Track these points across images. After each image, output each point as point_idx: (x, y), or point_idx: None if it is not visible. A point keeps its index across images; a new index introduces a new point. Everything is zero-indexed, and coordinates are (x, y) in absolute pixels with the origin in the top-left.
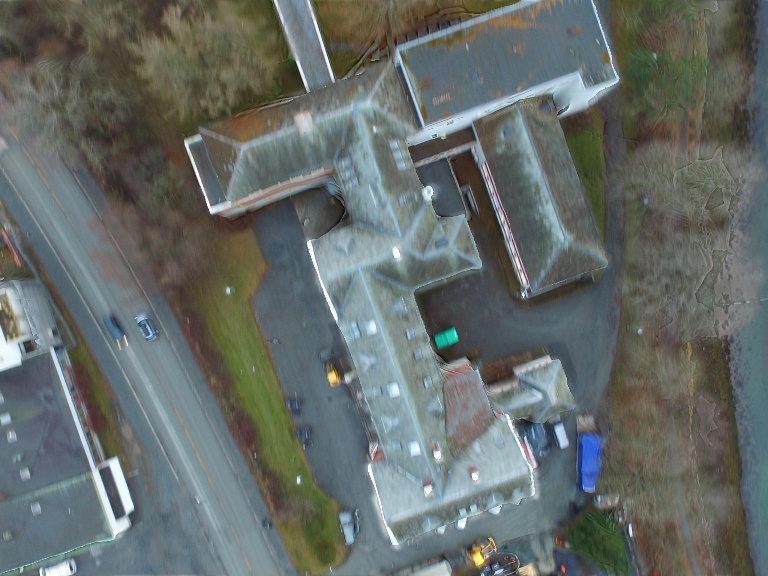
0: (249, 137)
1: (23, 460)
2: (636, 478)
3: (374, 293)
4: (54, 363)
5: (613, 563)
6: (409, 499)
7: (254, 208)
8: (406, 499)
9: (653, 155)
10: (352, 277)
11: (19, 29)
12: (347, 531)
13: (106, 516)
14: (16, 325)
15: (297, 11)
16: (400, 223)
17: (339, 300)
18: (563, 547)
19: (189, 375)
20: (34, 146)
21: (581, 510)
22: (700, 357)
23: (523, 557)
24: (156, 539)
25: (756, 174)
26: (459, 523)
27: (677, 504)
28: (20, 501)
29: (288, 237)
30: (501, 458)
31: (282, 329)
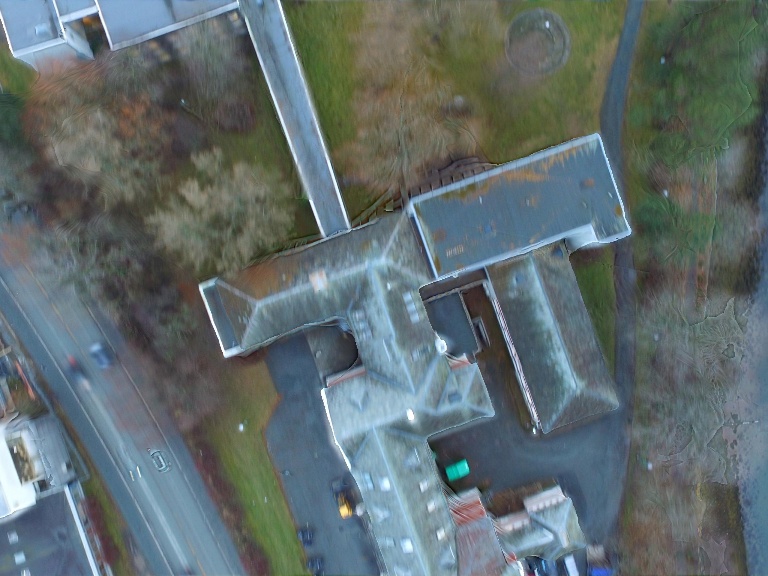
0: (264, 293)
1: None
2: None
3: (388, 450)
4: (68, 502)
5: None
6: None
7: (267, 343)
8: None
9: (663, 286)
10: (366, 434)
11: (37, 191)
12: None
13: None
14: (31, 467)
15: (311, 151)
16: (414, 379)
17: (353, 453)
18: None
19: (201, 506)
20: (48, 280)
21: None
22: None
23: None
24: None
25: (765, 294)
26: None
27: None
28: None
29: (300, 369)
30: None
31: (294, 460)
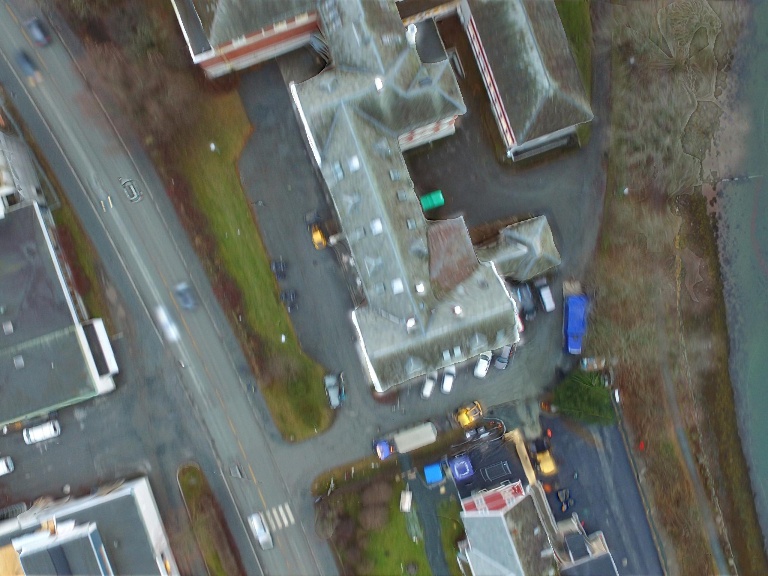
0: None
1: (6, 313)
2: (623, 345)
3: (357, 128)
4: (37, 216)
5: (598, 410)
6: (392, 337)
7: (239, 67)
8: (389, 337)
9: (640, 19)
10: (335, 112)
11: None
12: (332, 393)
13: (89, 370)
14: None
15: None
16: (383, 60)
17: (322, 140)
18: (549, 411)
19: (174, 237)
20: (18, 5)
21: (567, 374)
22: (688, 232)
23: (509, 423)
24: (140, 402)
25: (744, 50)
26: (445, 386)
27: (664, 377)
28: (3, 355)
29: (273, 99)
30: (484, 297)
31: (267, 192)
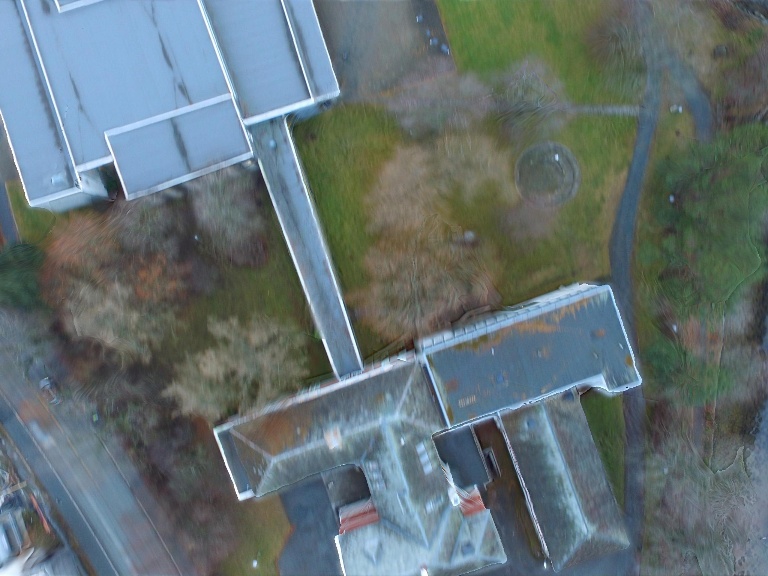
0: (279, 449)
1: None
2: None
3: None
4: None
5: None
6: None
7: None
8: None
9: (672, 416)
10: None
11: (55, 353)
12: None
13: None
14: None
15: (323, 290)
16: (427, 532)
17: None
18: None
19: None
20: (63, 415)
21: None
22: None
23: None
24: None
25: None
26: None
27: None
28: None
29: (313, 500)
30: None
31: None
